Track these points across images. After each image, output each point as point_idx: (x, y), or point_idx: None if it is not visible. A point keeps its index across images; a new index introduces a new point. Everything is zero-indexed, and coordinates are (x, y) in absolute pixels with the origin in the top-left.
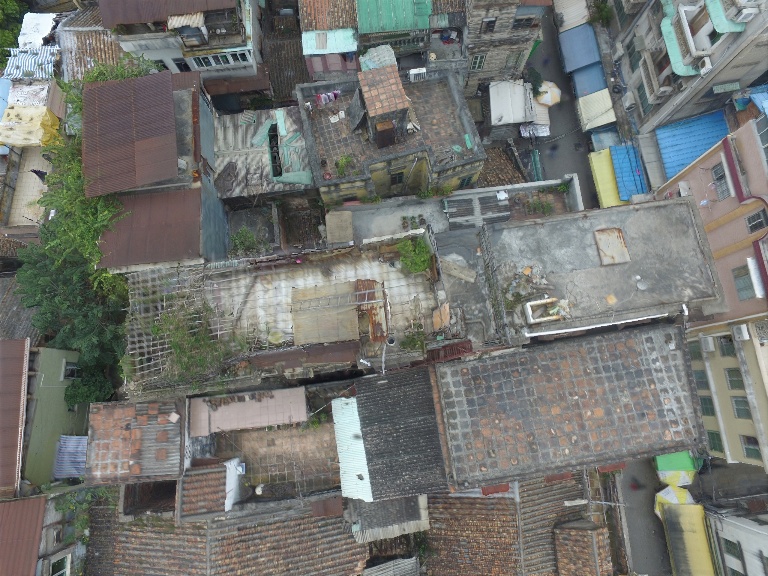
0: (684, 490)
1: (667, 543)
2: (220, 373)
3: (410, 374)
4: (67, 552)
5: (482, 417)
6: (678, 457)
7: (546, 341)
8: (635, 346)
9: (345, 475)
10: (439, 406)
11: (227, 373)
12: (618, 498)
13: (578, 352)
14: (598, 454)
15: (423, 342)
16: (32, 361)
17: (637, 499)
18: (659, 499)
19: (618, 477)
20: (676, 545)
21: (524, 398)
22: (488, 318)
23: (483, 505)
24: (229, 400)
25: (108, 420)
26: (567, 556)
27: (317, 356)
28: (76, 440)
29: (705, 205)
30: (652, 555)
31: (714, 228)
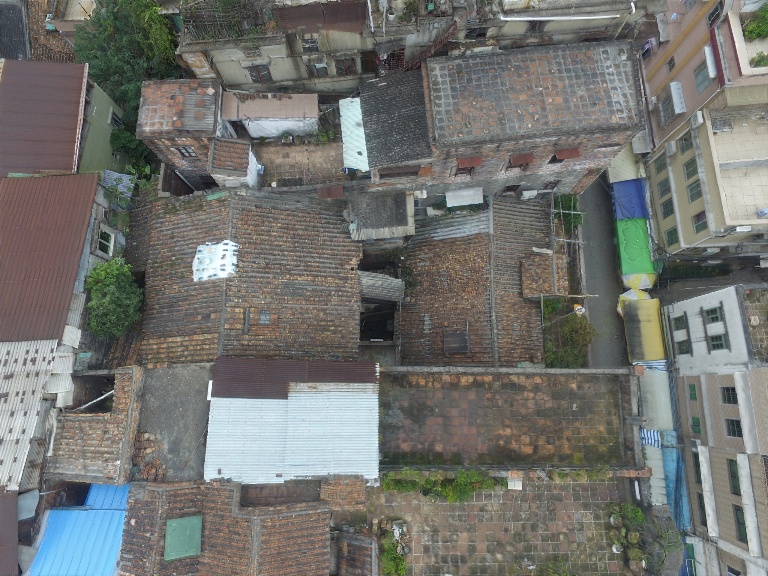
0: (644, 292)
1: (625, 334)
2: (253, 24)
3: (406, 77)
4: (112, 231)
5: (462, 100)
6: (641, 262)
7: (519, 47)
8: (593, 56)
9: (347, 152)
10: (428, 91)
11: (259, 26)
12: (579, 244)
13: (545, 57)
14: (555, 128)
15: (417, 18)
16: (88, 91)
17: (603, 309)
18: (621, 298)
19: (580, 228)
20: (633, 333)
21: (498, 88)
22: (471, 5)
23: (462, 241)
24: (255, 95)
25: (157, 92)
26: (530, 278)
27: (331, 24)
28: (118, 176)
29: (675, 19)
30: (613, 355)
31: (682, 40)
